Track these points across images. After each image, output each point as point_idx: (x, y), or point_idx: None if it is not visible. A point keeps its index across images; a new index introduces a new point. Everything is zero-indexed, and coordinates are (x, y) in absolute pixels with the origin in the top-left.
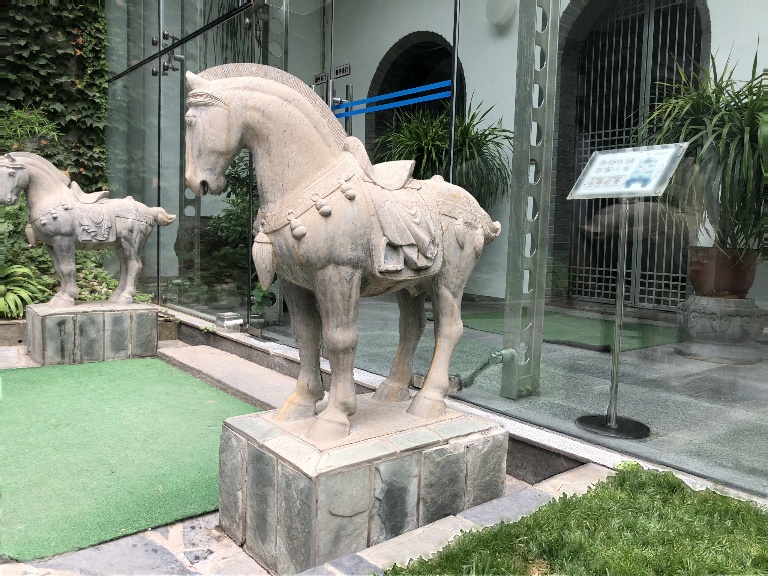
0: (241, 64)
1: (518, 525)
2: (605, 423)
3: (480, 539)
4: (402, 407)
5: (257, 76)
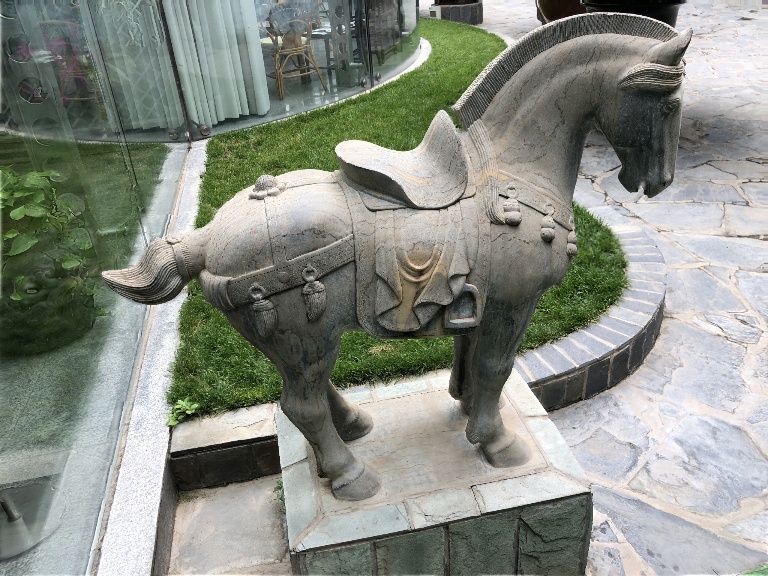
0: (616, 13)
1: (364, 366)
2: (3, 532)
3: (403, 359)
4: (366, 444)
5: (592, 30)
